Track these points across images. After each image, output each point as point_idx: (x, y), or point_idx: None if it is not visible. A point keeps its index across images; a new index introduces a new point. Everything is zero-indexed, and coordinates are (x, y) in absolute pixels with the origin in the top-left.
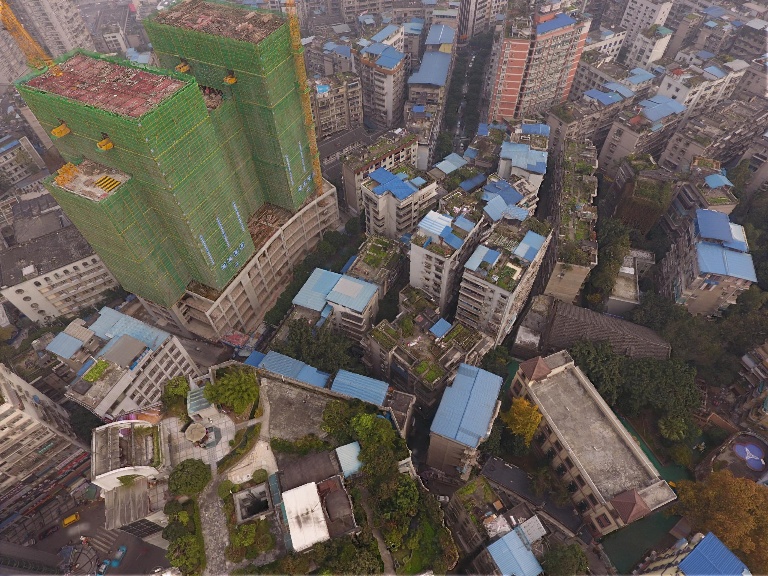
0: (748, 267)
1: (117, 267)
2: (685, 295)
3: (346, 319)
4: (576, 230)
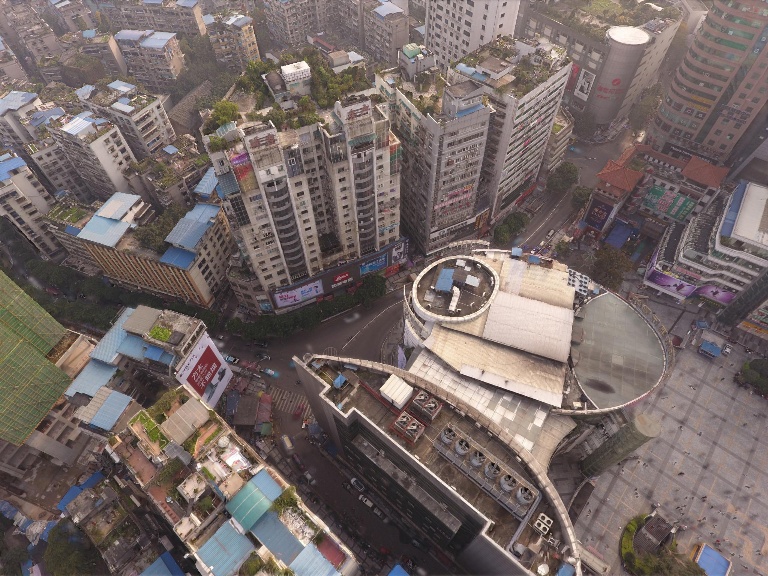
0: (165, 34)
1: (0, 405)
2: (172, 70)
3: (142, 214)
4: None
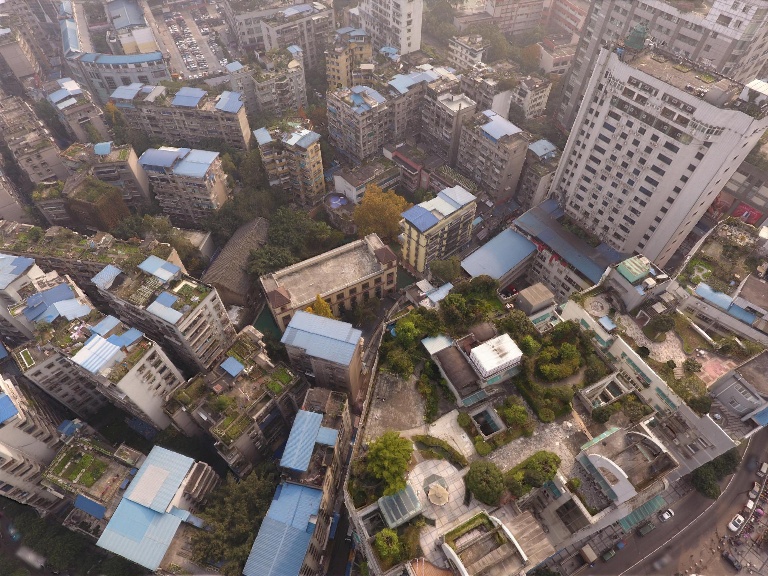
0: (205, 153)
1: None
2: (213, 200)
3: (196, 486)
4: (122, 253)
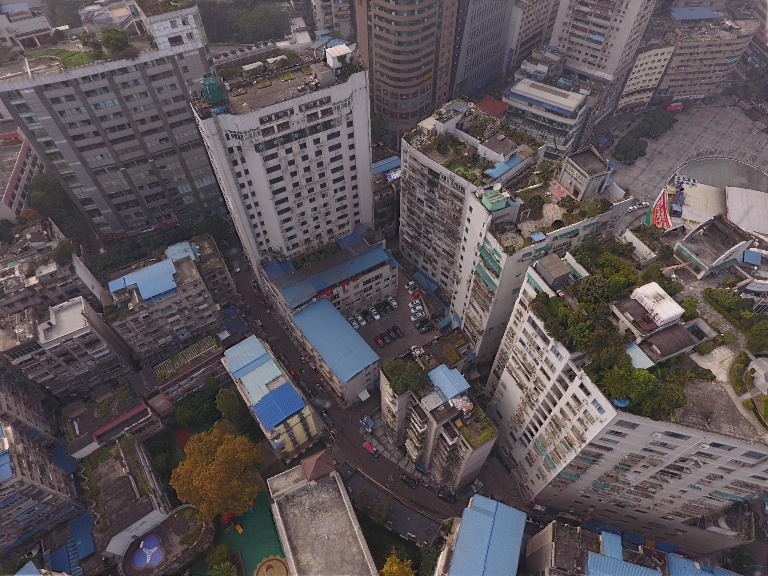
0: None
1: None
2: None
3: None
4: None
